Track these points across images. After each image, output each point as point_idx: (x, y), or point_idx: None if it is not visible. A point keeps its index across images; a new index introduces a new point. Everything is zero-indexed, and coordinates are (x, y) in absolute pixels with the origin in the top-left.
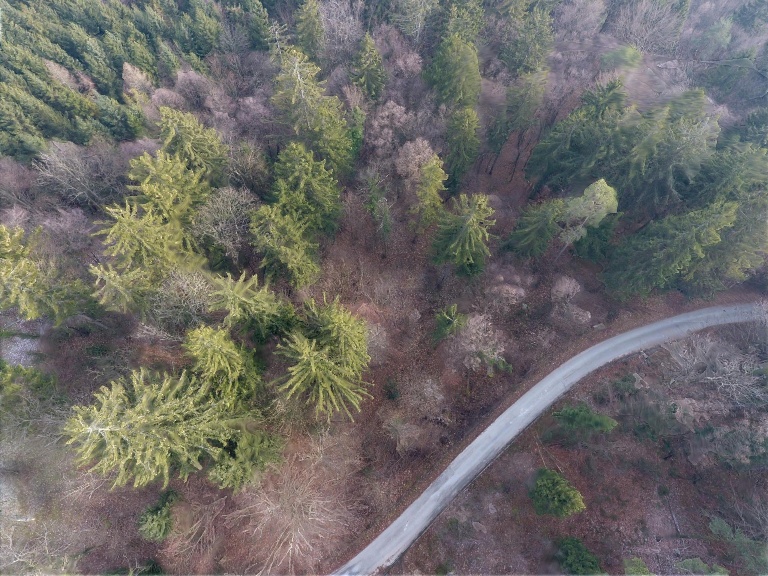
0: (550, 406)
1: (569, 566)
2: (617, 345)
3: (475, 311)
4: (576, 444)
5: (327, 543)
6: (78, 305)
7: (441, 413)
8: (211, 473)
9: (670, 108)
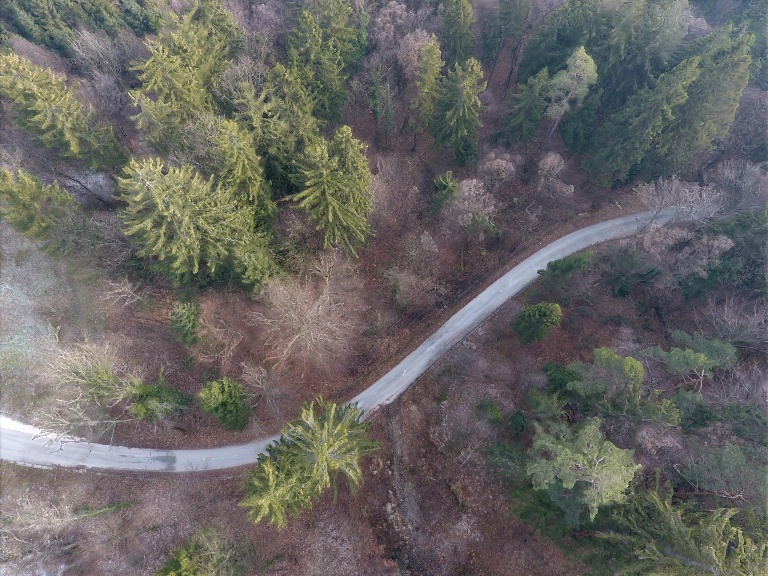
0: (537, 279)
1: (548, 376)
2: (600, 231)
3: None
4: (558, 296)
5: (333, 385)
6: (111, 157)
7: (437, 285)
8: (237, 251)
9: (648, 0)
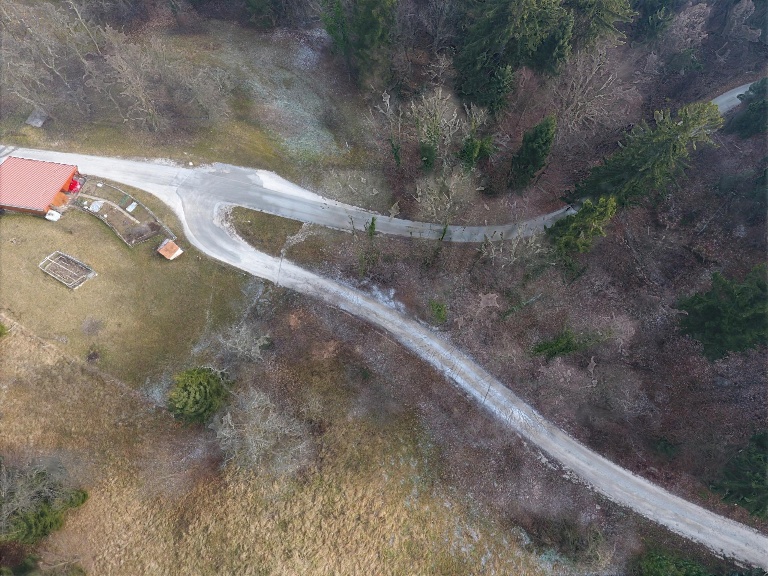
0: None
1: None
2: None
3: (678, 15)
4: None
5: (563, 189)
6: None
7: None
8: None
9: None
